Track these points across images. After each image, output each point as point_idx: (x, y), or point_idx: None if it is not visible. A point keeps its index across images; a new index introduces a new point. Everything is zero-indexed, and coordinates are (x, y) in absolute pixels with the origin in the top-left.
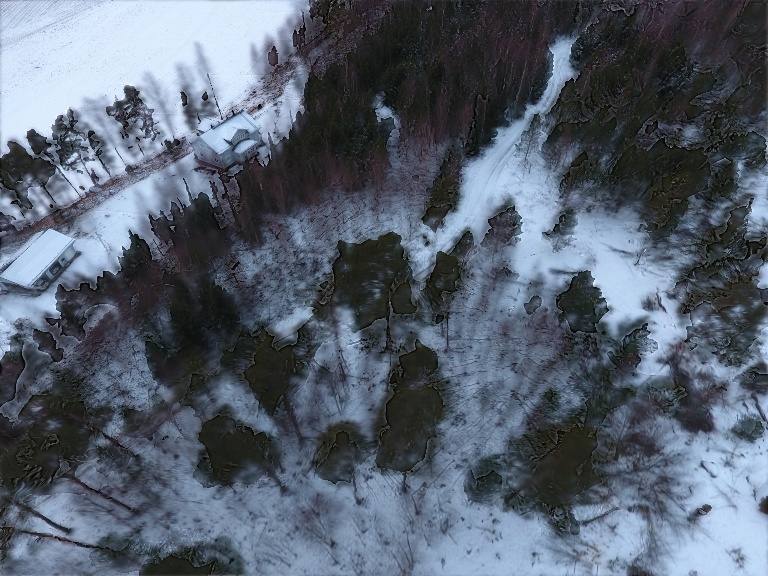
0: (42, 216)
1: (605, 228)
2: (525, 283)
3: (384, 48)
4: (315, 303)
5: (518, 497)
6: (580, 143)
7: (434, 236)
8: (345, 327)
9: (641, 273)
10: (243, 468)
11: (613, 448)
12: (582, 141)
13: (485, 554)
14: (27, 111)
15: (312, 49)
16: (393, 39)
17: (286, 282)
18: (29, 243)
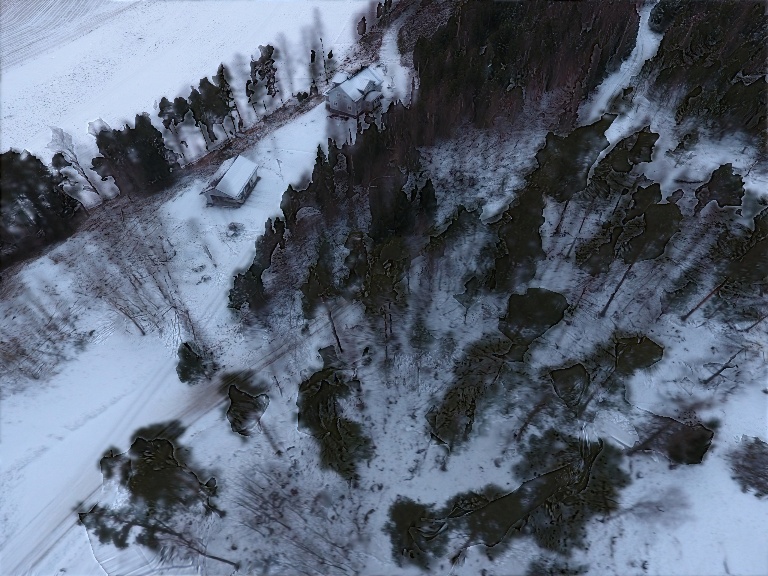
0: (193, 159)
1: (712, 152)
2: None
3: (484, 12)
4: (533, 178)
5: (701, 308)
6: (687, 83)
7: None
8: (552, 198)
9: (751, 182)
10: (530, 265)
11: (757, 289)
12: (689, 81)
13: (676, 349)
14: (144, 76)
15: (393, 20)
16: (492, 4)
17: (451, 193)
18: (226, 166)
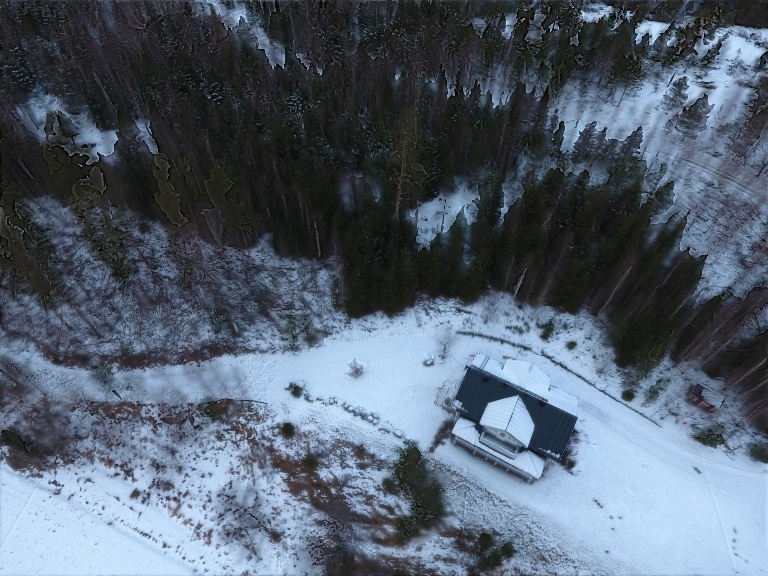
0: None
1: None
2: (713, 130)
3: None
4: None
5: None
6: None
7: (680, 170)
8: None
9: None
10: None
11: None
12: None
13: None
14: None
15: None
16: None
17: None
18: None
